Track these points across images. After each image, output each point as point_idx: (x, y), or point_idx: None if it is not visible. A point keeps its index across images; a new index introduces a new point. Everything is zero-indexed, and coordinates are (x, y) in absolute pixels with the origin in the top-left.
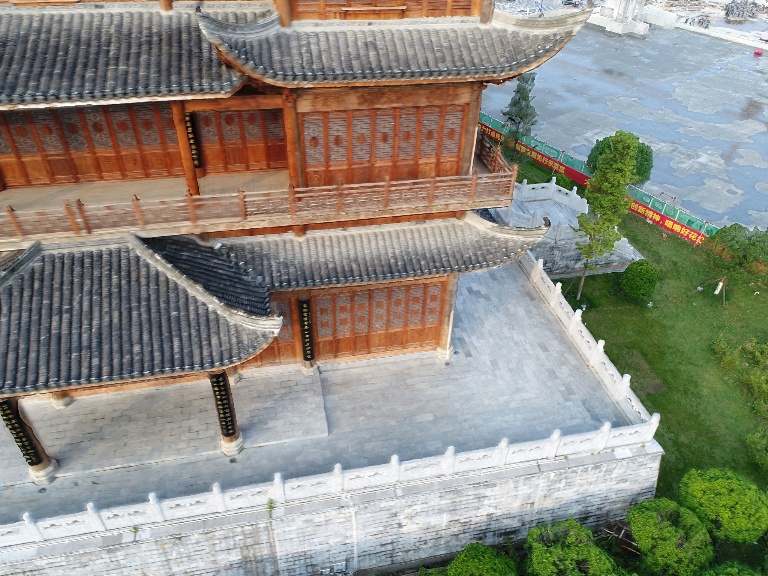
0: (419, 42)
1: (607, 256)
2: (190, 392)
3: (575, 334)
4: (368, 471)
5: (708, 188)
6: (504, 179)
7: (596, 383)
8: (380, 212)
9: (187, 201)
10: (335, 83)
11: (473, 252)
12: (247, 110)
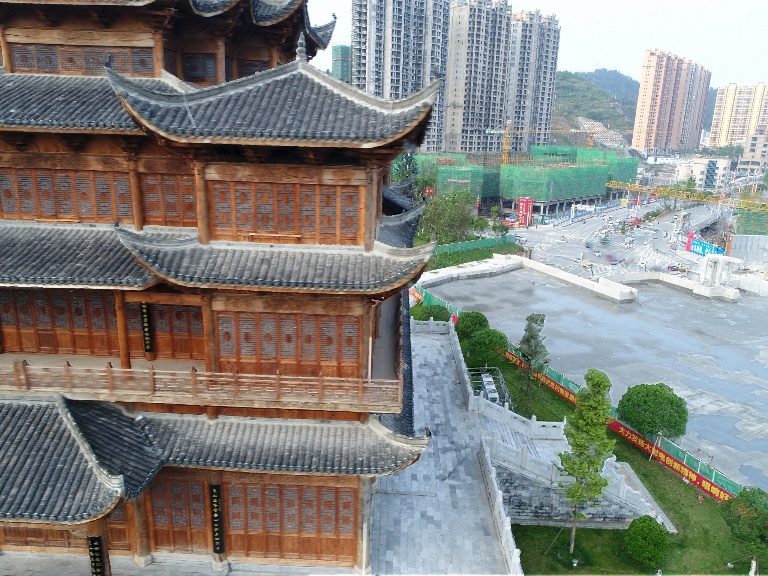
0: (306, 261)
1: (616, 509)
2: None
3: None
4: None
5: None
6: (391, 386)
7: None
8: (273, 403)
9: (107, 372)
10: (224, 286)
11: (367, 456)
12: (173, 305)
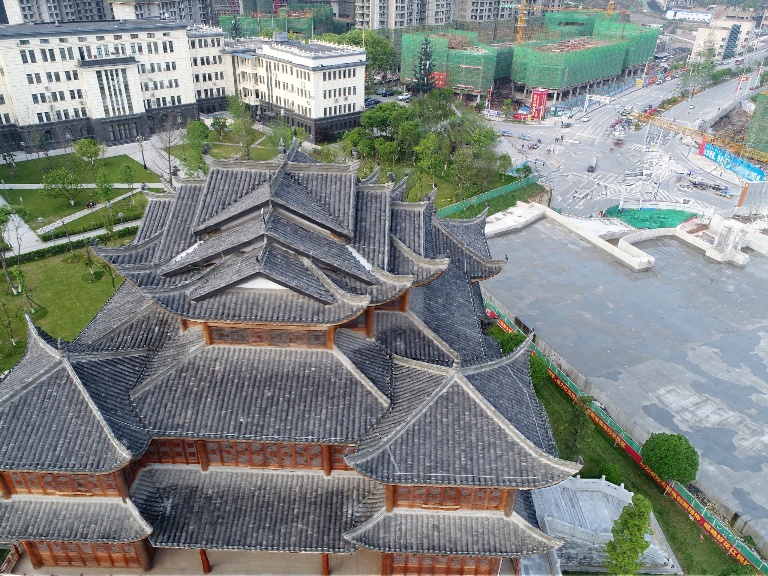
0: (465, 527)
1: (640, 559)
2: None
3: None
4: None
5: (763, 476)
6: None
7: None
8: None
9: None
10: None
11: None
12: None
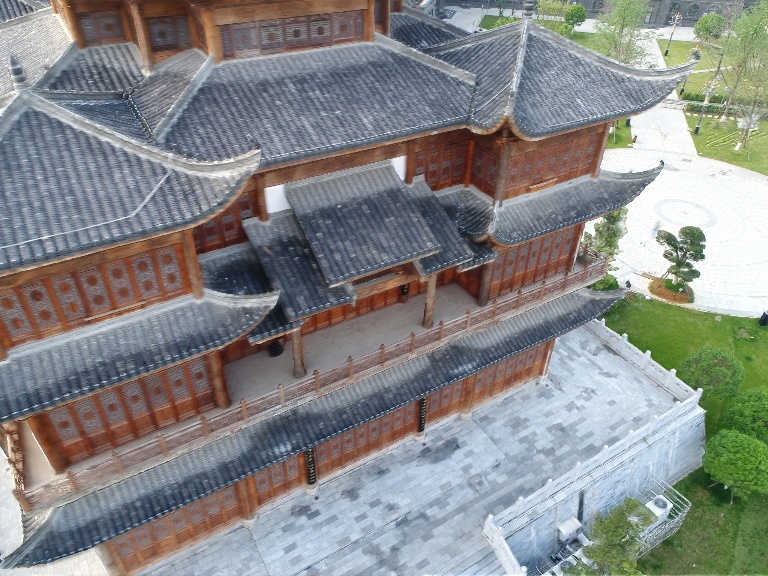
0: None
1: None
2: None
3: None
4: None
5: None
6: None
7: None
8: None
9: None
10: None
11: (38, 521)
12: None
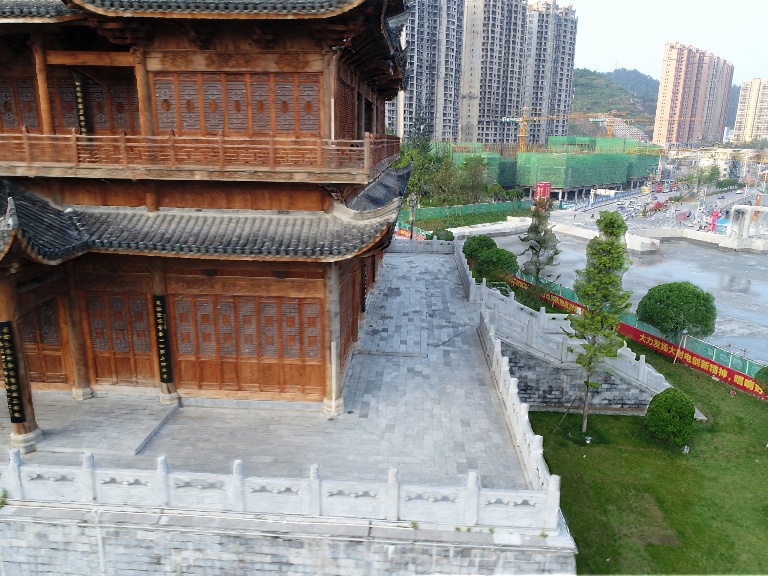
0: None
1: (636, 393)
2: (34, 399)
3: (510, 412)
4: (126, 473)
5: None
6: (355, 148)
7: (515, 463)
8: (217, 174)
9: (23, 138)
10: (150, 11)
11: (329, 240)
12: (102, 66)
